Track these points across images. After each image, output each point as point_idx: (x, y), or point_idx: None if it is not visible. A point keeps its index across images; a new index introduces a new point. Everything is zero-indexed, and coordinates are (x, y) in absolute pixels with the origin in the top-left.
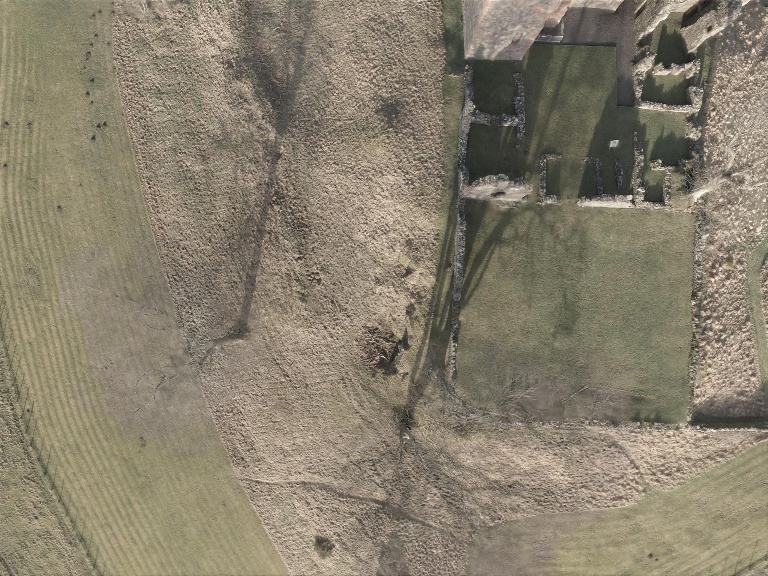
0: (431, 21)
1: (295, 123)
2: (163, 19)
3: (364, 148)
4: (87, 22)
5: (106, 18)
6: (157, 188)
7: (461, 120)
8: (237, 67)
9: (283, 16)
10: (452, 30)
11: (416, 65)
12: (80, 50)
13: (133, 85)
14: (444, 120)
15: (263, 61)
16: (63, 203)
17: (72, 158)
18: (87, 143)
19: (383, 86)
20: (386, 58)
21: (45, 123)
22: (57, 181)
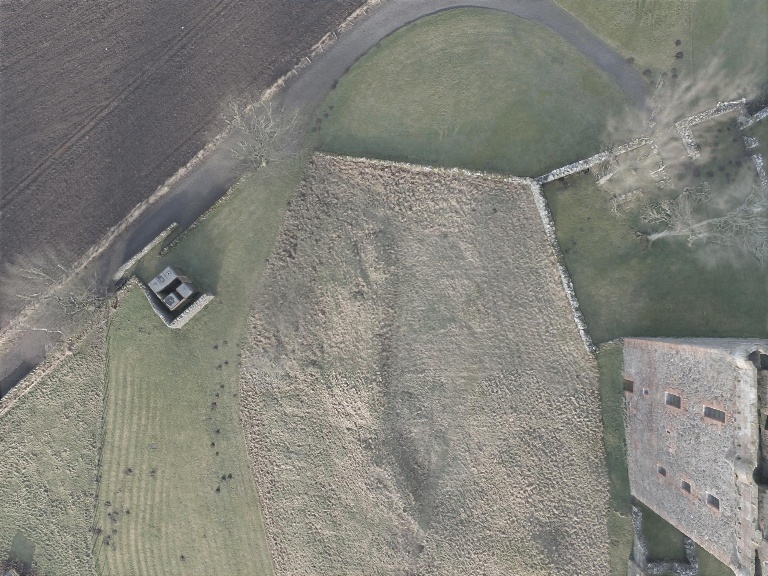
0: (592, 444)
1: (438, 517)
2: (293, 378)
3: (520, 573)
4: (213, 373)
5: (233, 369)
6: (284, 545)
7: (632, 572)
8: (376, 450)
9: (425, 401)
10: (614, 454)
11: (577, 492)
12: (206, 401)
13: (260, 438)
14: (610, 562)
15: (403, 444)
16: (186, 553)
17: (196, 508)
18: (212, 494)
19: (540, 508)
20: (543, 478)
21: (169, 472)
22: (180, 531)
